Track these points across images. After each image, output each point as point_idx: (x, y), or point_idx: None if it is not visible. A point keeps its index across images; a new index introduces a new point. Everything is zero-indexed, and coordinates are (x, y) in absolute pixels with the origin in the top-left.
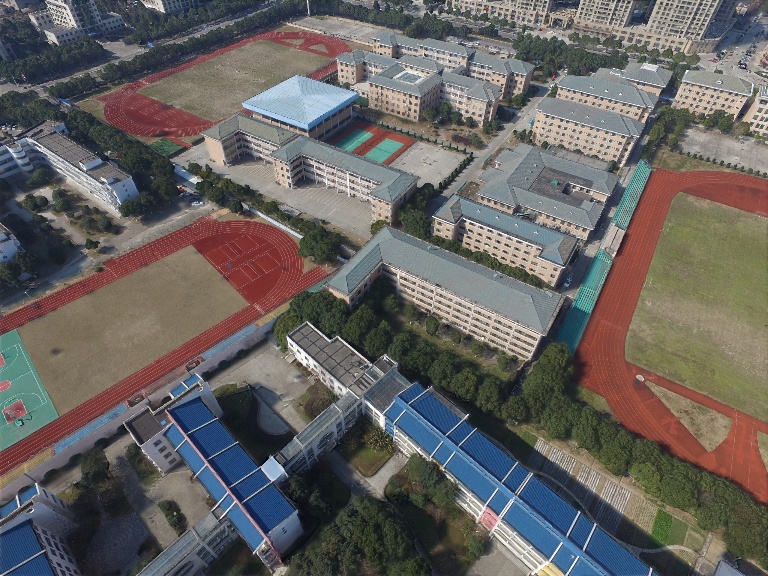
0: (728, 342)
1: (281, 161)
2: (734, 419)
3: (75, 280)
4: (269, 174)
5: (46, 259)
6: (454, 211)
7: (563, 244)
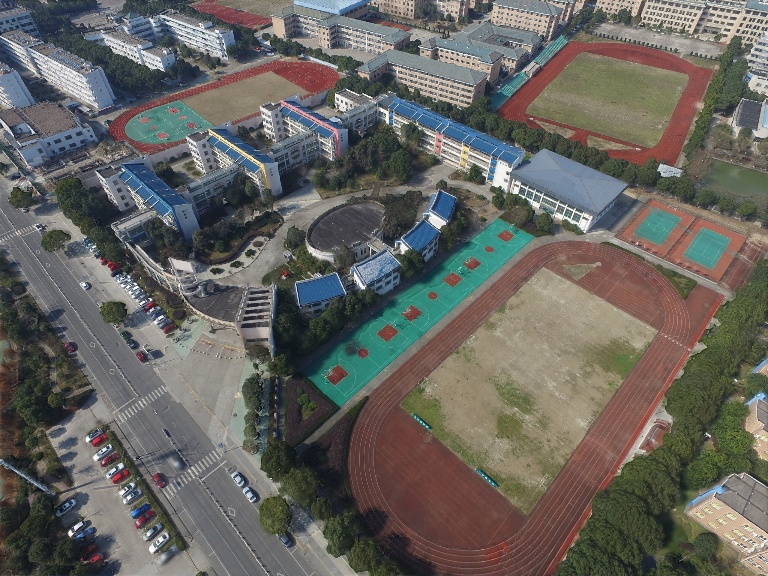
0: (587, 108)
1: (324, 27)
2: (578, 131)
3: (206, 83)
4: (314, 42)
5: (185, 75)
6: (431, 43)
7: (493, 54)
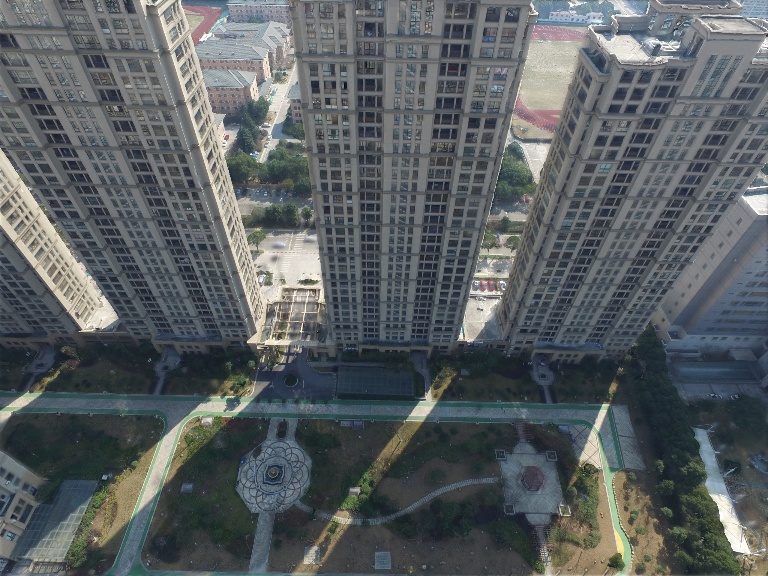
0: None
1: None
2: None
3: None
4: None
5: None
6: None
7: None
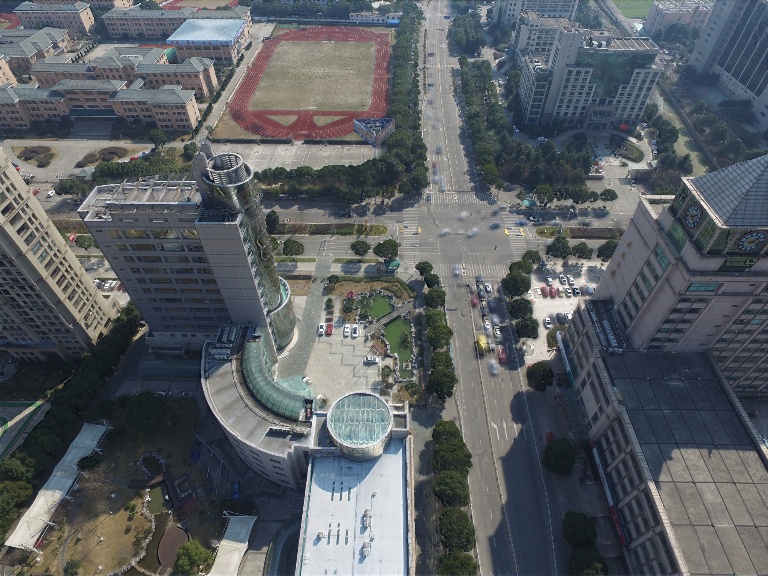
0: None
1: None
2: None
3: None
4: None
5: None
6: None
7: None
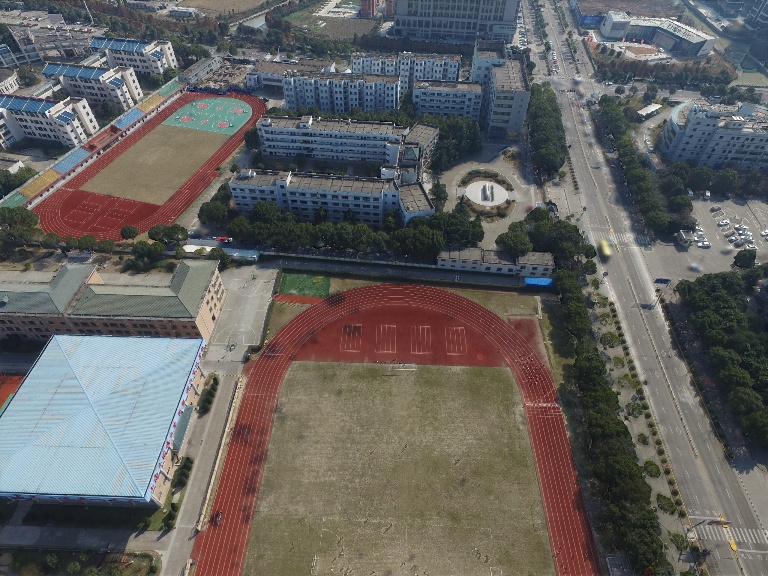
0: None
1: None
2: None
3: (229, 160)
4: None
5: (268, 161)
6: None
7: None
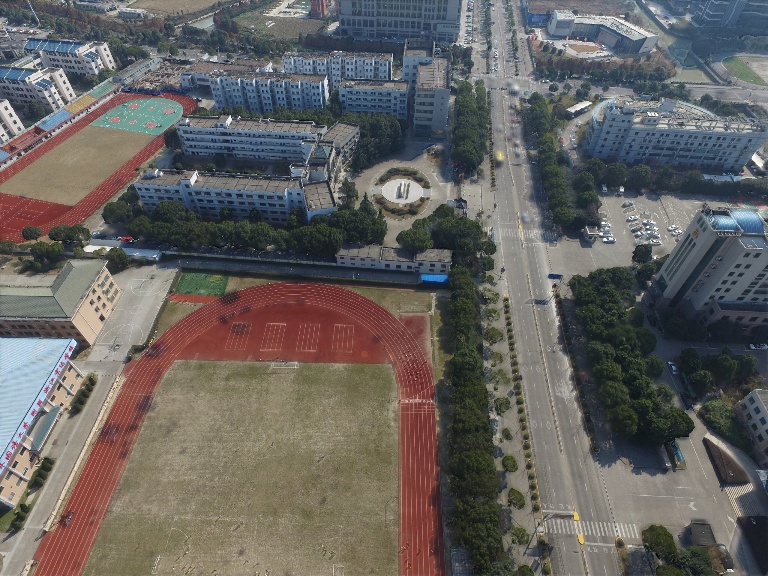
0: None
1: None
2: None
3: (150, 160)
4: None
5: (189, 161)
6: None
7: None
